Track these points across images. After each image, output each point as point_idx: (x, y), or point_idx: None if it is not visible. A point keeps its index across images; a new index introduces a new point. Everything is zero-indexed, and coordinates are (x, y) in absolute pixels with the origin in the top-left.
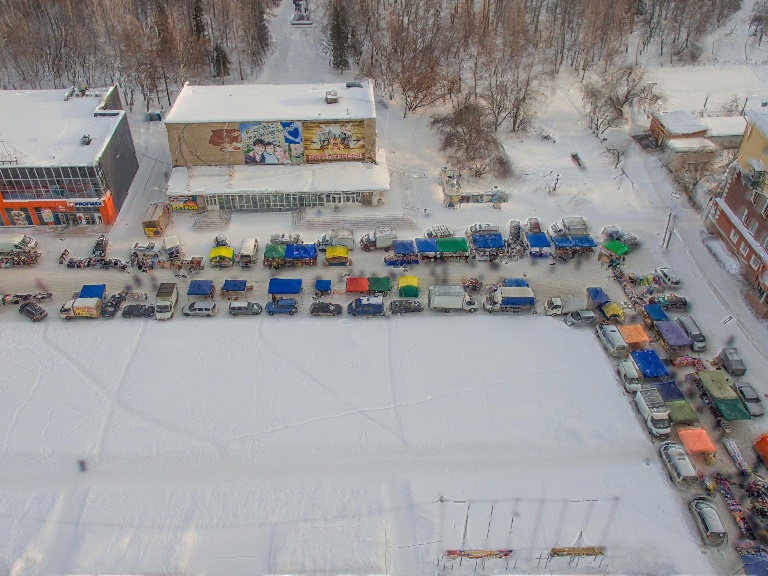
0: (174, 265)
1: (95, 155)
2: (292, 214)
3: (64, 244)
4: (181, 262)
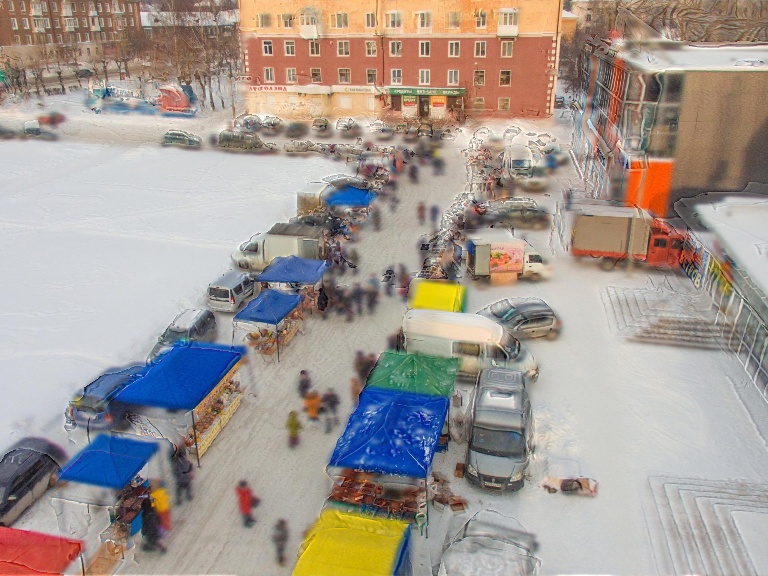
0: (425, 261)
1: (671, 66)
2: (764, 479)
3: (530, 195)
4: (430, 265)
